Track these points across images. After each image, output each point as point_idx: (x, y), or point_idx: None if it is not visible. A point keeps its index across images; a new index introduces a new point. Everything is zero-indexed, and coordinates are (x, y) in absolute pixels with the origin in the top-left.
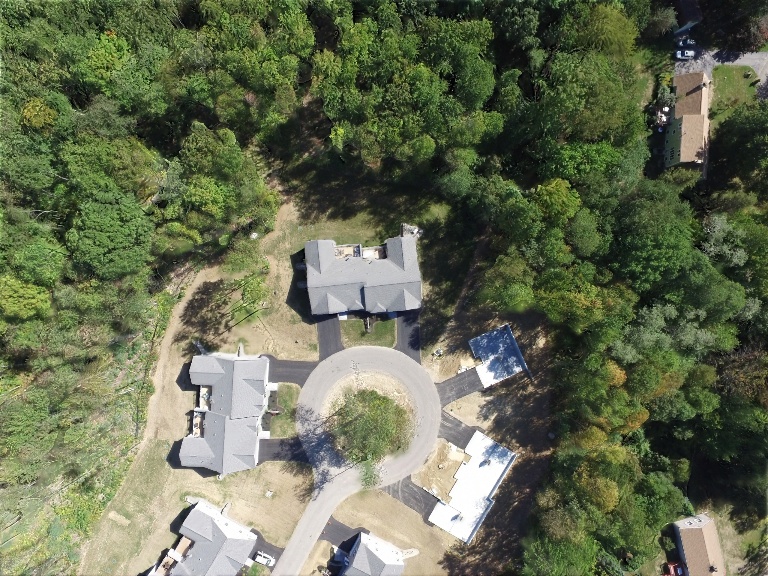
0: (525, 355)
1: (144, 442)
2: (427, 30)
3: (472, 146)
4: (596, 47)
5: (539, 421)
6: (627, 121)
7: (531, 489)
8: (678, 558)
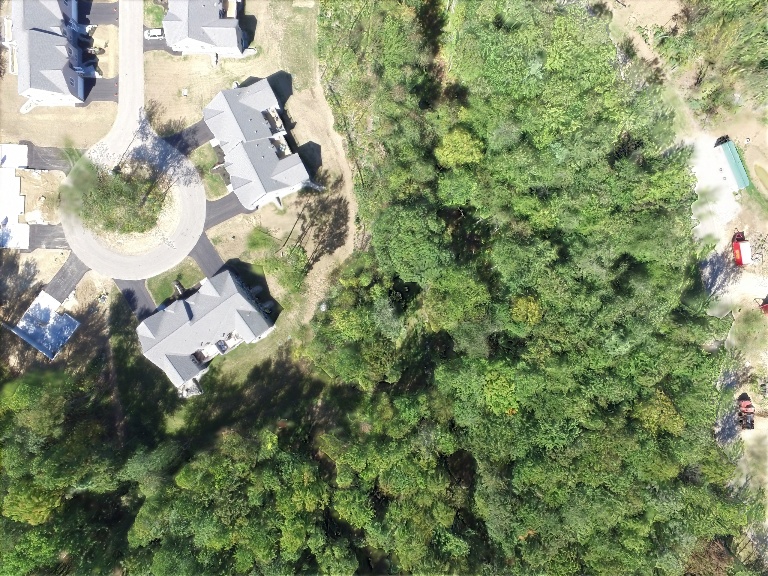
0: (21, 341)
1: (318, 80)
2: None
3: None
4: None
5: None
6: None
7: None
8: None
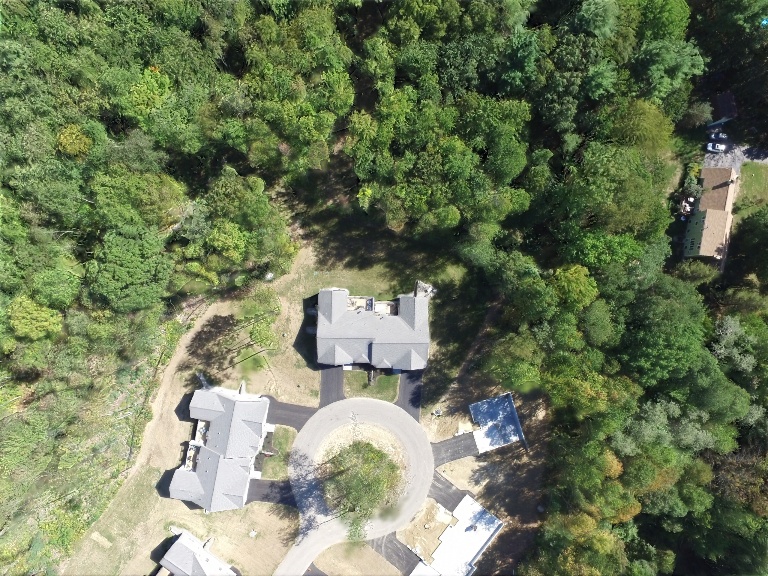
0: (524, 425)
1: (136, 467)
2: (466, 105)
3: (496, 222)
4: (630, 140)
5: (530, 492)
6: (652, 217)
7: (514, 560)
8: None
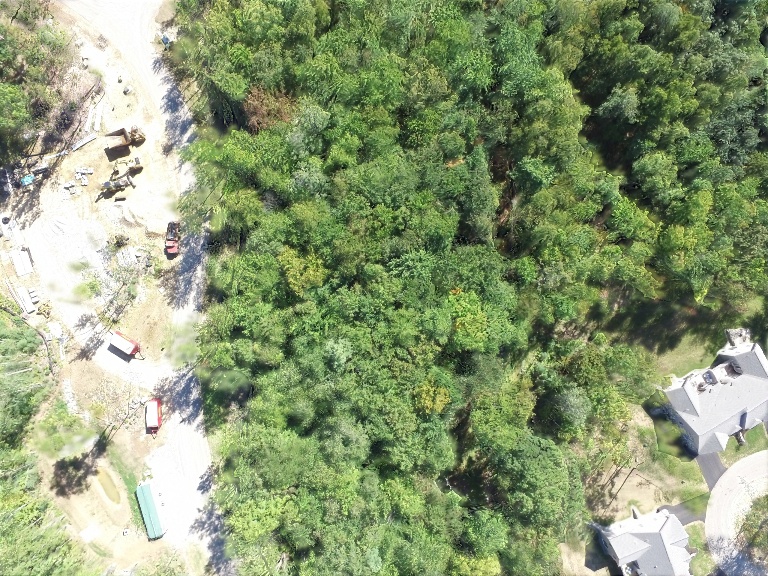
0: None
1: None
2: (761, 170)
3: None
4: None
5: None
6: None
7: None
8: None
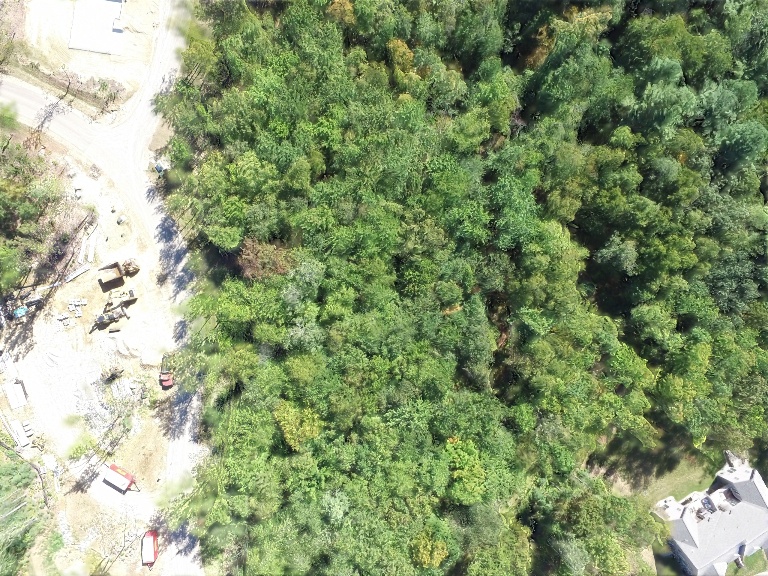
0: None
1: None
2: (760, 321)
3: None
4: None
5: None
6: None
7: None
8: None
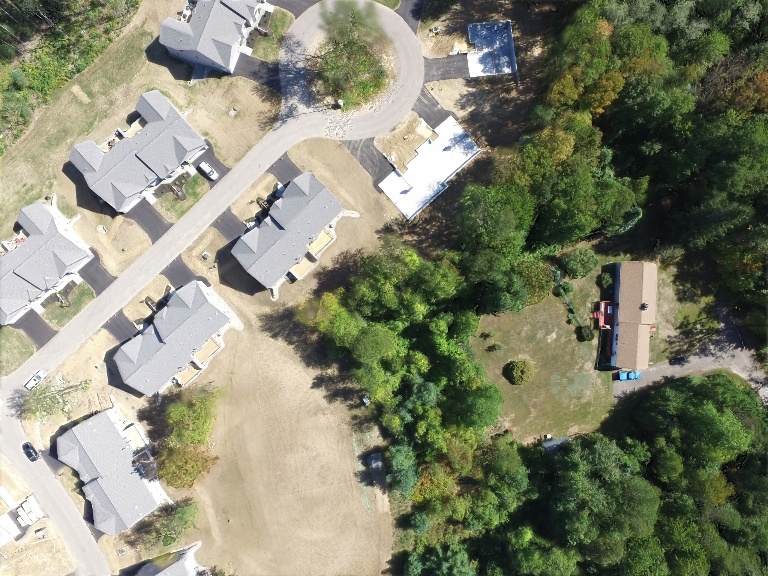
0: (518, 57)
1: (130, 27)
2: None
3: None
4: None
5: (513, 125)
6: None
7: None
8: (612, 298)
